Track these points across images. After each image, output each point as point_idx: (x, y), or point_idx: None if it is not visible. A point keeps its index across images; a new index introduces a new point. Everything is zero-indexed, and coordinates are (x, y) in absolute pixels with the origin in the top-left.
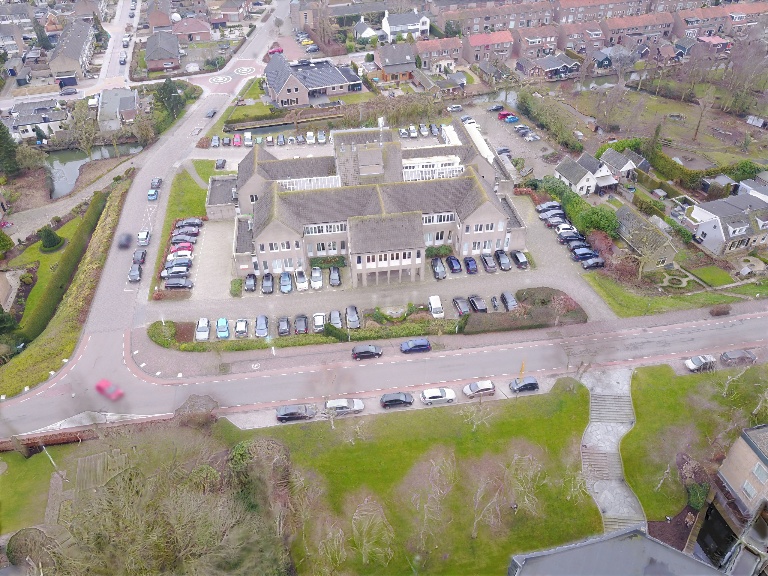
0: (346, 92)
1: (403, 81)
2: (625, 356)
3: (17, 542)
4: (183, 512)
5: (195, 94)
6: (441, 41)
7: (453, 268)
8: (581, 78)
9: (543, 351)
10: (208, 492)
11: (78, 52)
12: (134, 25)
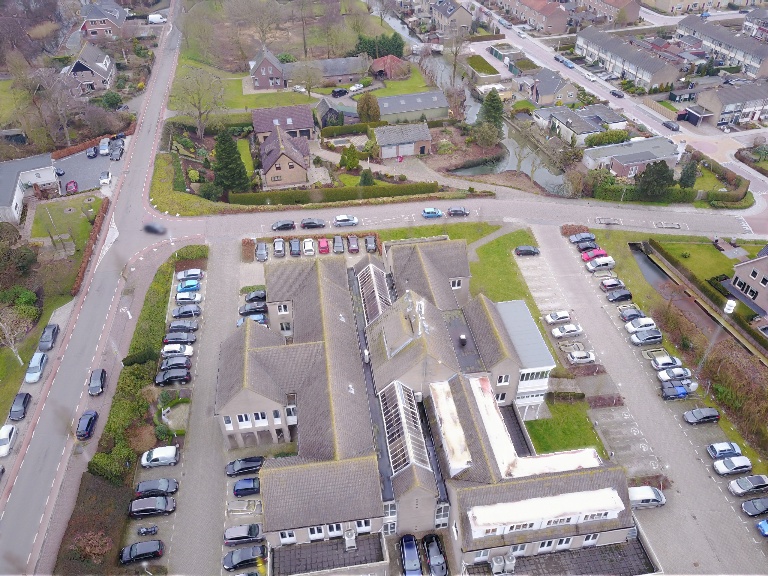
0: None
1: None
2: None
3: None
4: (4, 295)
5: (721, 202)
6: None
7: None
8: None
9: (14, 568)
10: (10, 302)
11: (744, 99)
12: None
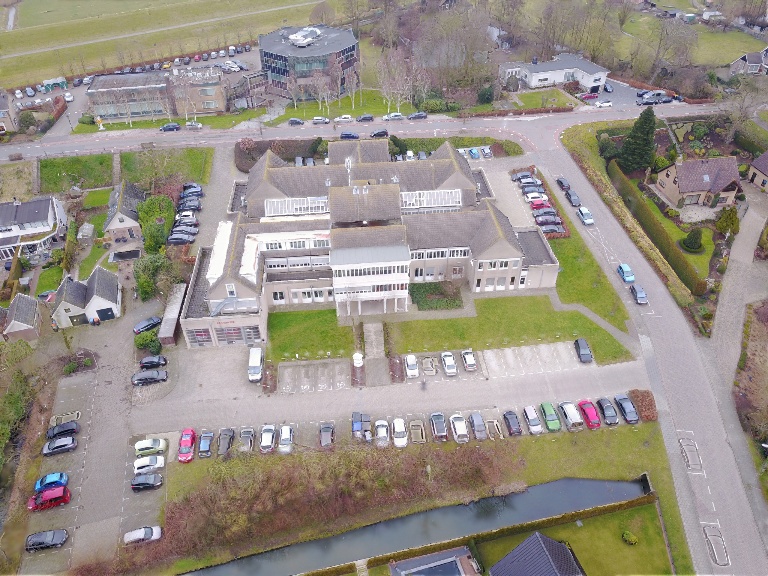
0: None
1: None
2: (230, 133)
3: None
4: None
5: None
6: None
7: None
8: None
9: (275, 135)
10: None
11: None
12: None
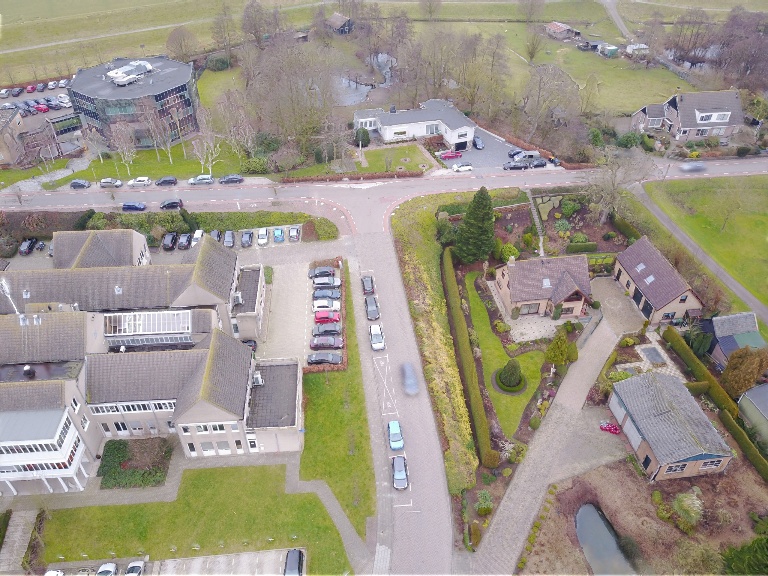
0: None
1: None
2: None
3: (362, 128)
4: None
5: None
6: None
7: None
8: None
9: (46, 203)
10: None
11: None
12: None
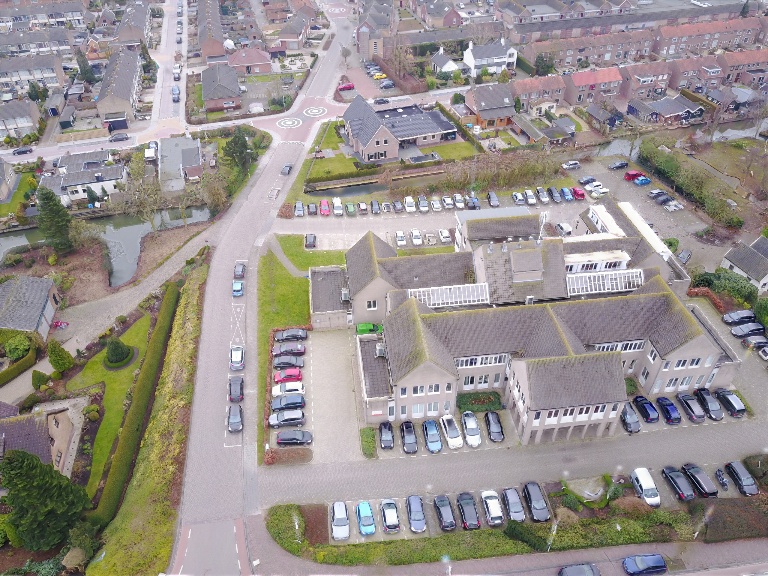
0: (438, 142)
1: (500, 127)
2: None
3: None
4: None
5: (264, 143)
6: (541, 80)
7: (649, 417)
8: (713, 128)
9: None
10: None
11: (128, 90)
12: (183, 53)
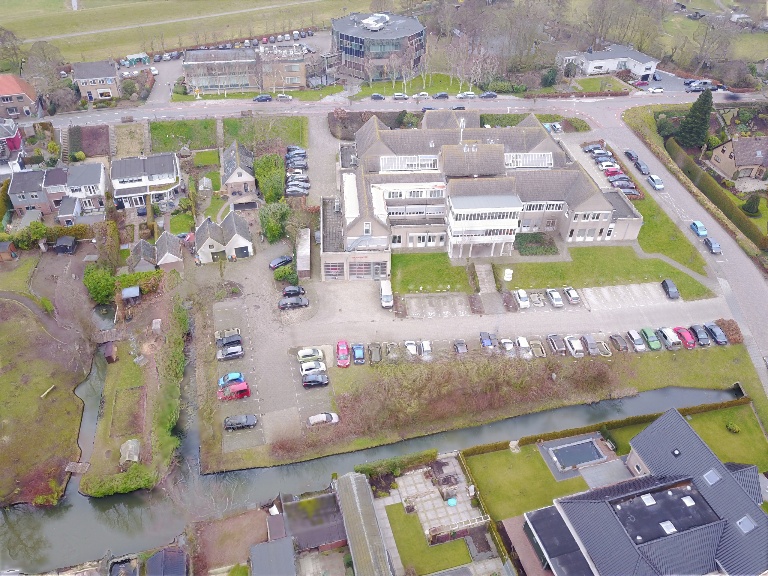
0: None
1: None
2: None
3: None
4: None
5: None
6: None
7: None
8: None
9: (361, 108)
10: None
11: None
12: None
